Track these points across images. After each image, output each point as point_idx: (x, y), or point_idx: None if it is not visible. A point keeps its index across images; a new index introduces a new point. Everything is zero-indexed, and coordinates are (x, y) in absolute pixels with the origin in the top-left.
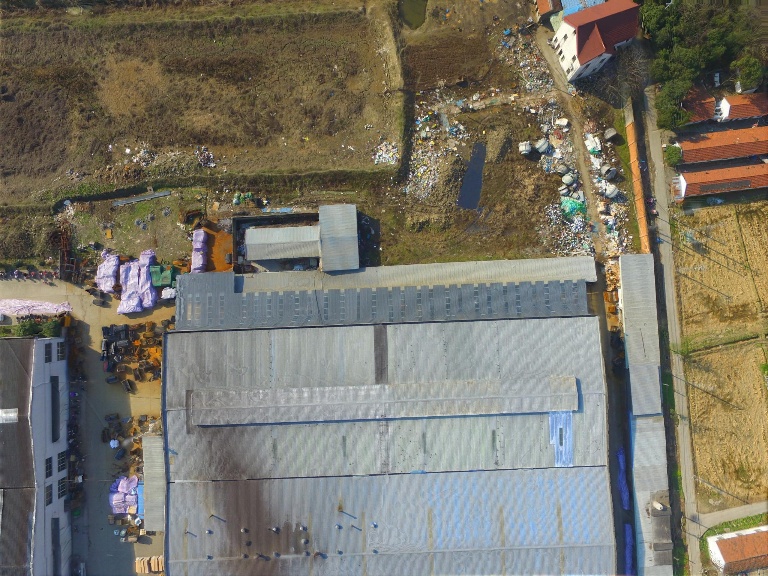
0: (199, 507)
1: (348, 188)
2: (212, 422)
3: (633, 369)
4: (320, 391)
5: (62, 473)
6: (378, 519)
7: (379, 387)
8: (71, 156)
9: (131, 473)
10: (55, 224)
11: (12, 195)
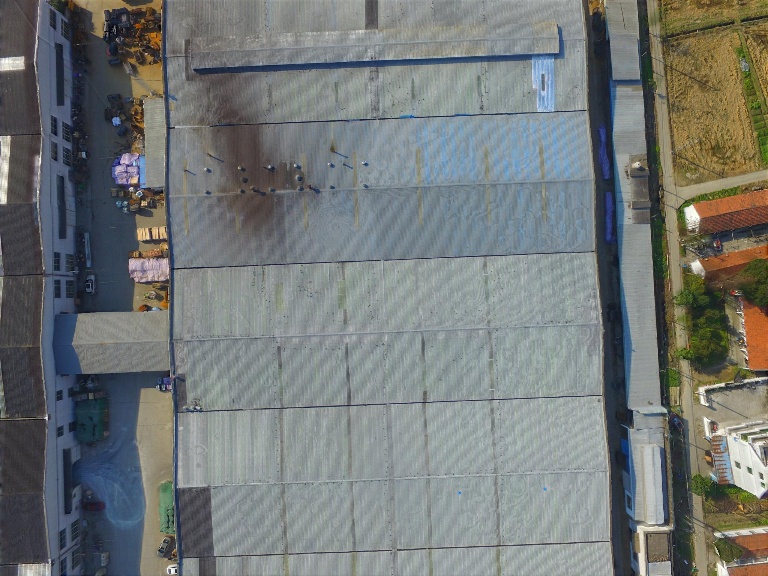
0: (198, 149)
1: None
2: (210, 65)
3: (613, 37)
4: (313, 35)
5: (66, 143)
6: (368, 158)
7: (369, 31)
8: None
9: (132, 150)
10: None
11: None
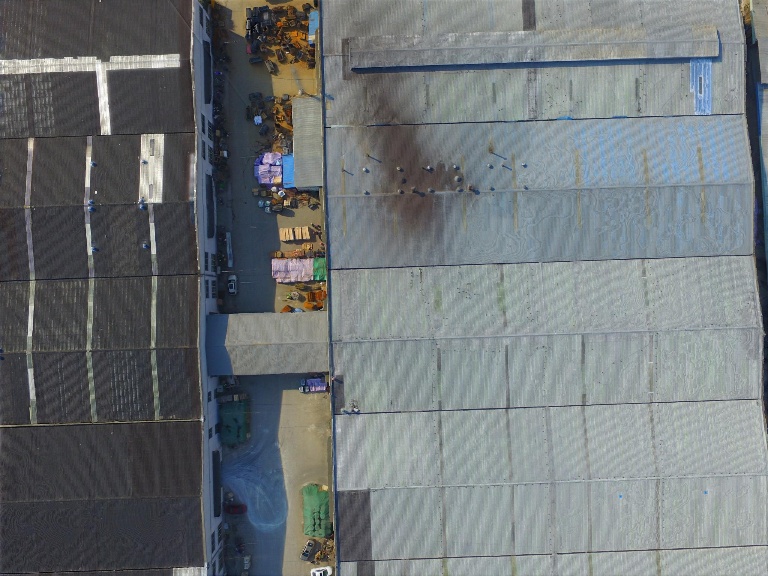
0: (355, 149)
1: None
2: (369, 64)
3: (761, 40)
4: (473, 35)
5: (210, 142)
6: (527, 160)
7: (529, 32)
8: None
9: (273, 150)
10: None
11: None
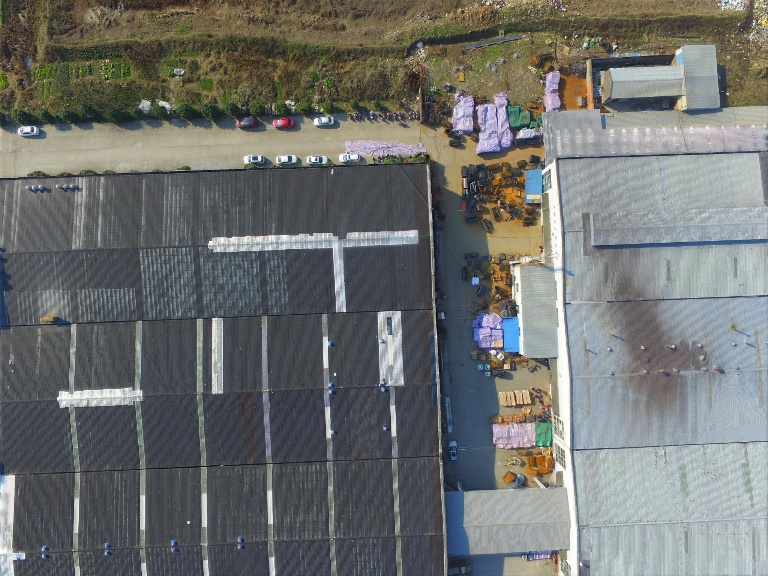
0: (597, 326)
1: (694, 35)
2: (613, 242)
3: None
4: (717, 212)
5: None
6: None
7: None
8: None
9: (490, 310)
10: (408, 66)
11: (365, 37)
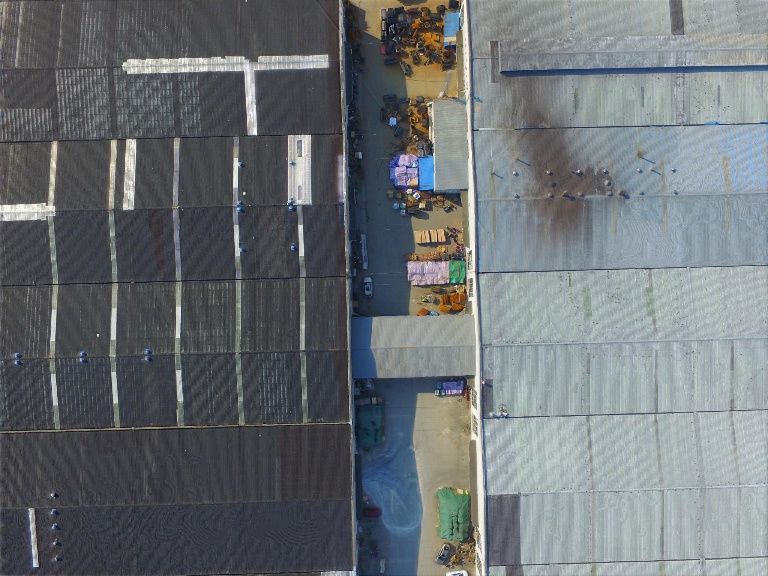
0: (504, 152)
1: None
2: (519, 67)
3: None
4: (624, 39)
5: None
6: (676, 164)
7: (680, 37)
8: None
9: (408, 152)
10: None
11: None
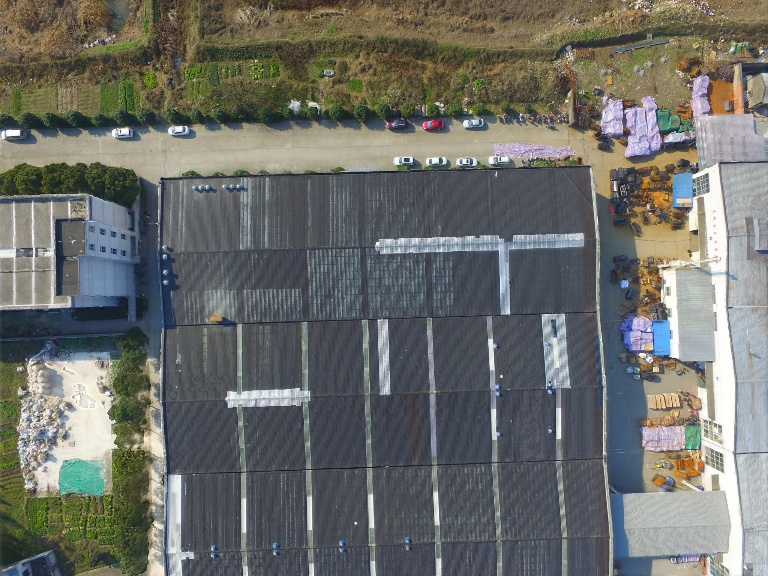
0: (760, 330)
1: None
2: None
3: None
4: None
5: None
6: None
7: None
8: (569, 3)
9: (638, 314)
10: (556, 69)
11: (514, 39)
